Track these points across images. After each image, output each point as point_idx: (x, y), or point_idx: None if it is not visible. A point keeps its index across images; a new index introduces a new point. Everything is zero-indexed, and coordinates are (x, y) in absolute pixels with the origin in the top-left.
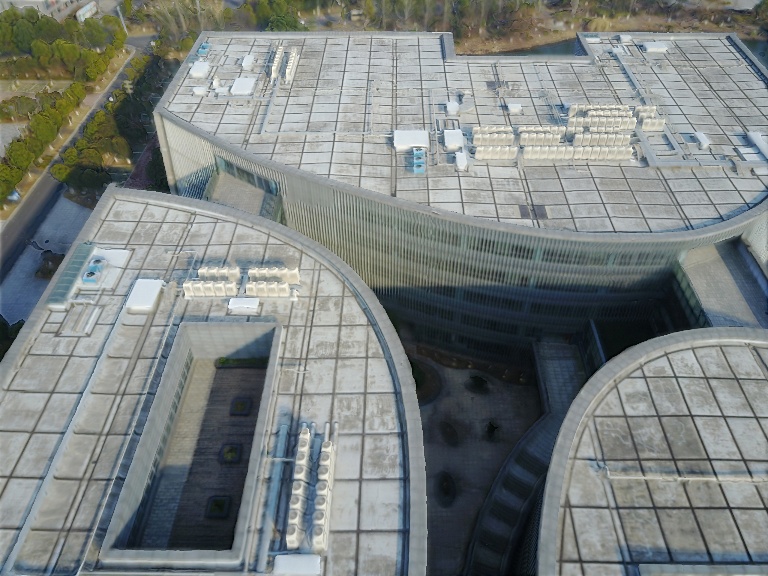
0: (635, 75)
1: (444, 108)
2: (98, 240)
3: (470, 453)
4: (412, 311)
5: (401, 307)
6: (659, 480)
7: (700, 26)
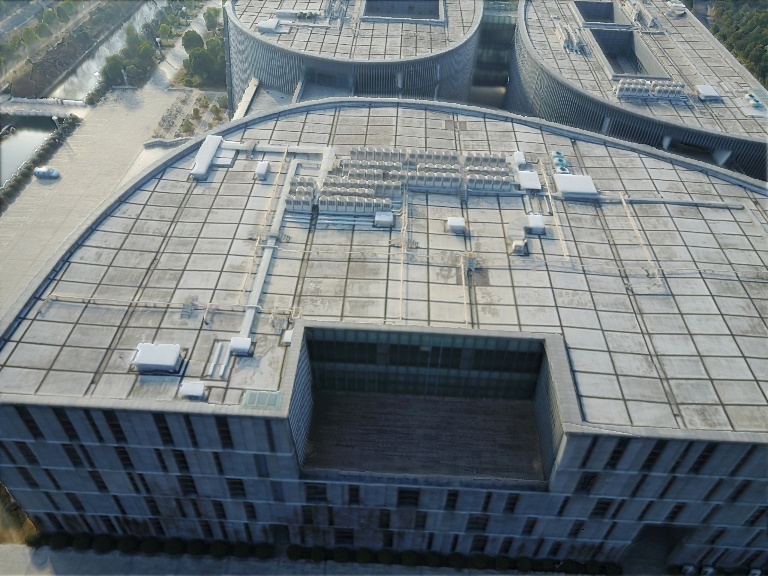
0: (251, 287)
1: (546, 232)
2: None
3: None
4: None
5: None
6: None
7: None
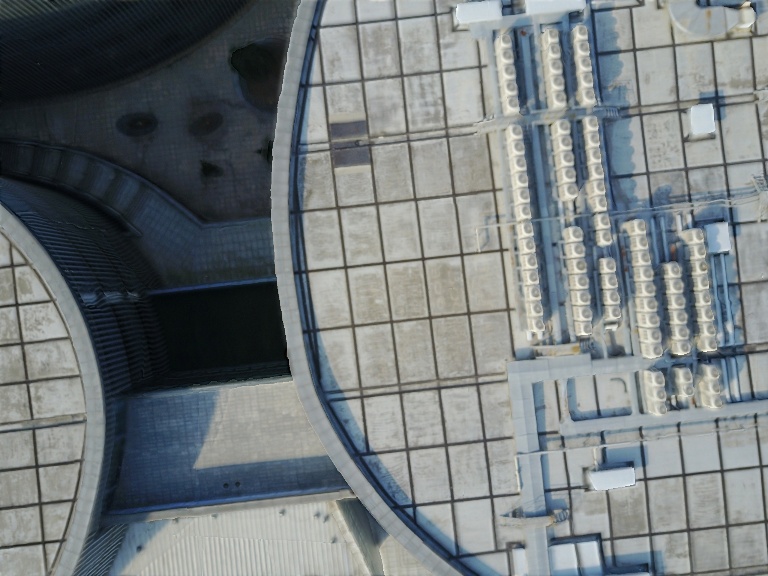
0: None
1: None
2: None
3: (184, 150)
4: None
5: None
6: None
7: None
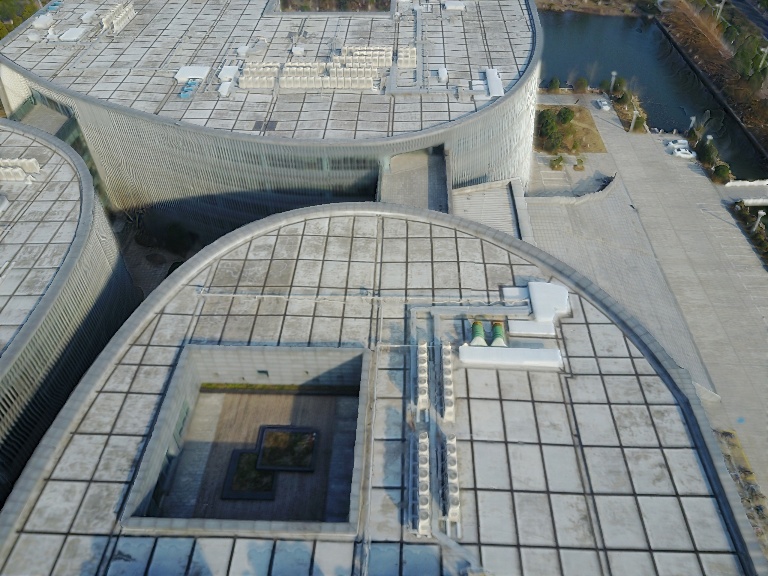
0: (423, 27)
1: None
2: None
3: None
4: (193, 222)
5: (185, 219)
6: (240, 297)
7: (580, 4)
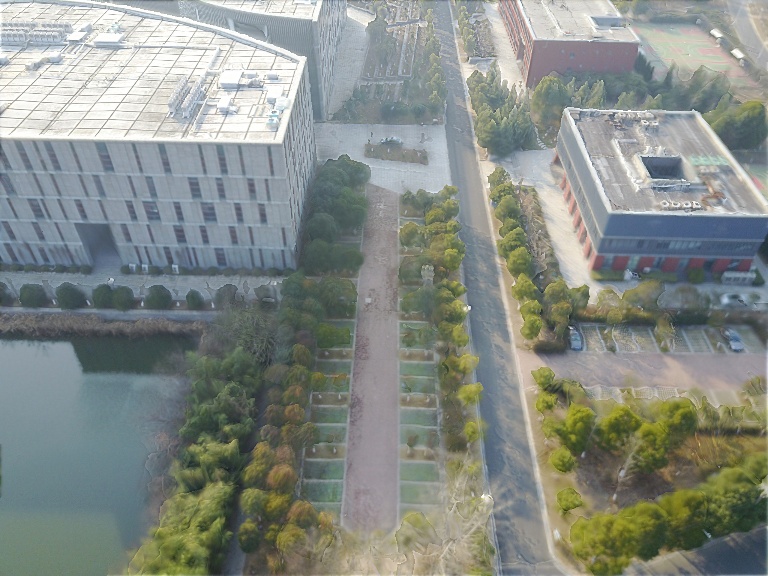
0: None
1: (60, 61)
2: (312, 6)
3: None
4: None
5: None
6: None
7: None
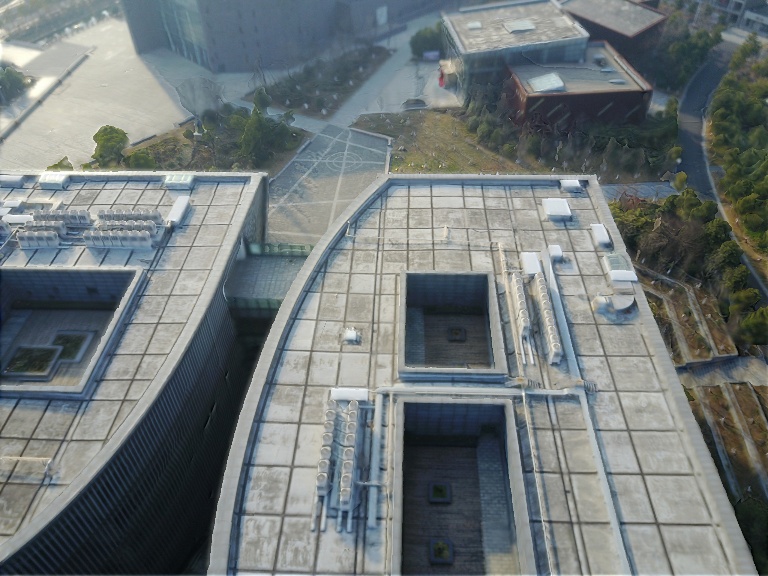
0: None
1: None
2: None
3: None
4: None
5: None
6: None
7: None
